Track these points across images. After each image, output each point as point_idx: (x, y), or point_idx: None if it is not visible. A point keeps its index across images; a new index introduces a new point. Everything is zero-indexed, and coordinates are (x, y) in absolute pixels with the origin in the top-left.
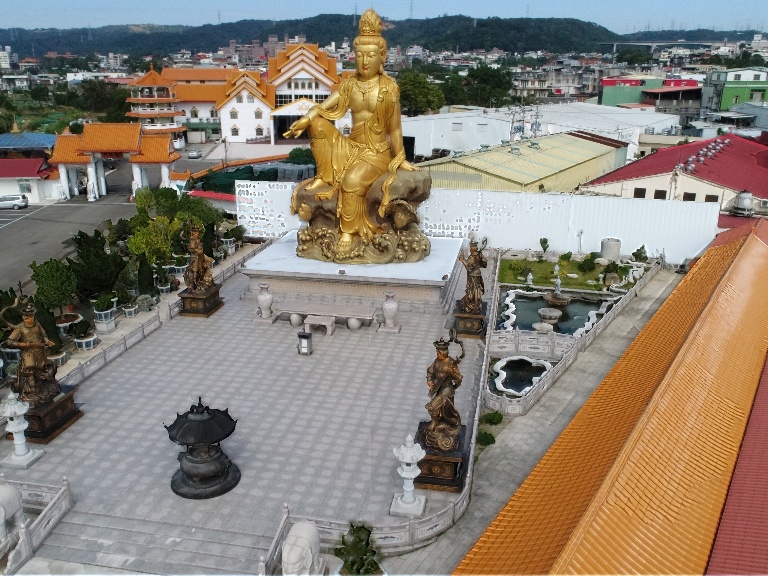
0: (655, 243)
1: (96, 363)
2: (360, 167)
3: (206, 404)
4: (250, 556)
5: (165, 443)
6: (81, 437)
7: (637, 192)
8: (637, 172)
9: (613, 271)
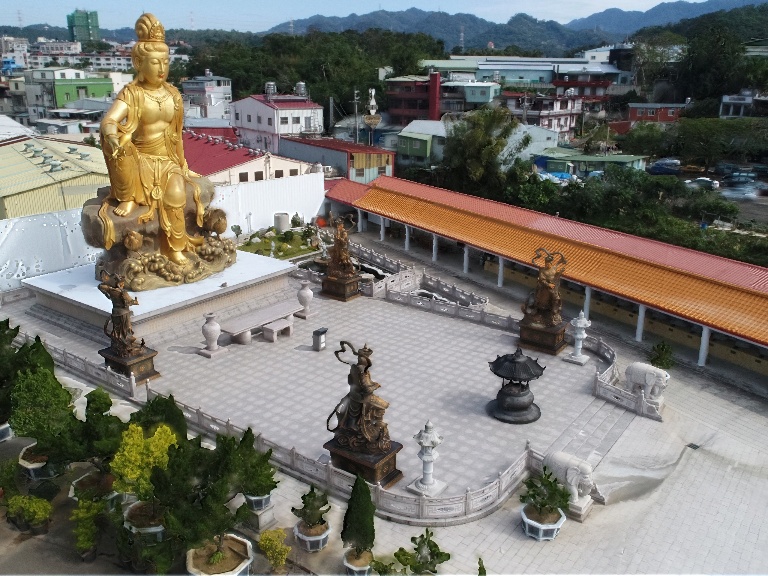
0: (294, 211)
1: (240, 436)
2: (178, 180)
3: (384, 398)
4: (609, 411)
5: (444, 421)
6: (402, 458)
7: (242, 176)
8: (200, 162)
9: (313, 234)
